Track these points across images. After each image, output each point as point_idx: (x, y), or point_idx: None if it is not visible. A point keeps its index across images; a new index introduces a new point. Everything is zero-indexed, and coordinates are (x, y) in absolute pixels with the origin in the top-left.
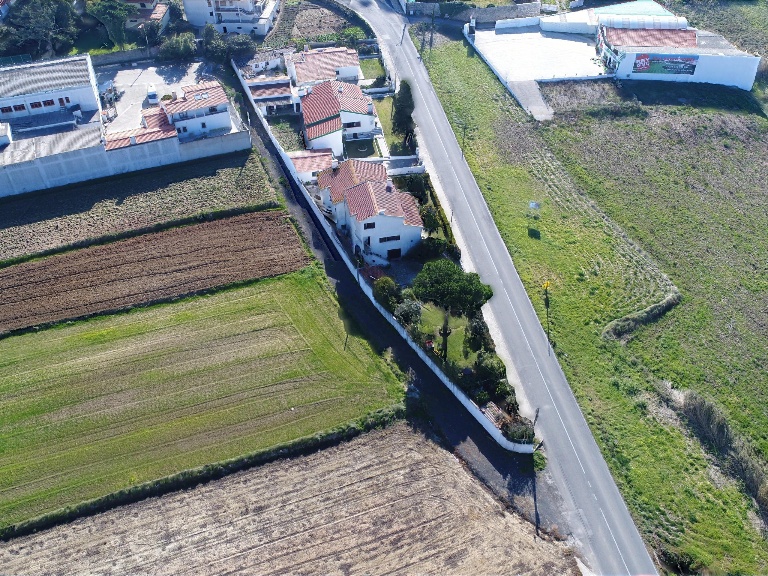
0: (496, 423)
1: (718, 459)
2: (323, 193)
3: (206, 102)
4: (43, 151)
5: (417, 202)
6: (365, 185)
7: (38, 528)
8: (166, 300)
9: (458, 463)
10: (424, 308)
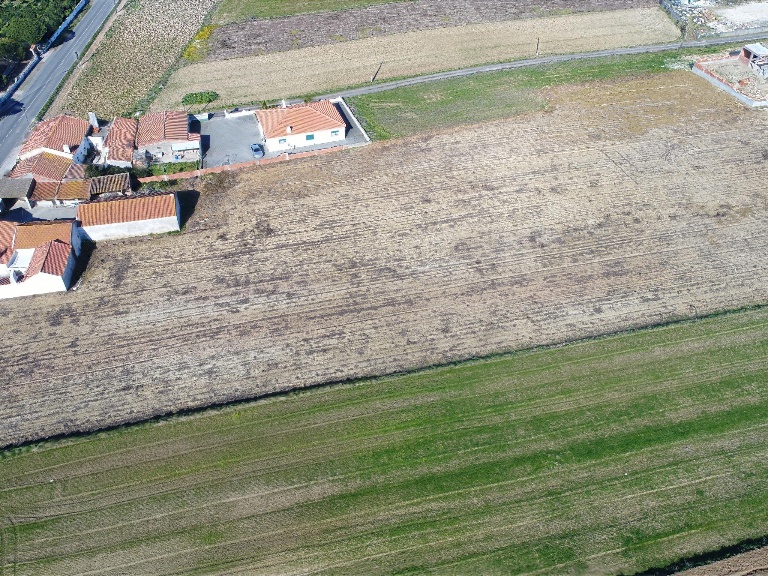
0: None
1: None
2: None
3: None
4: None
5: None
6: None
7: (323, 385)
8: None
9: None
10: None
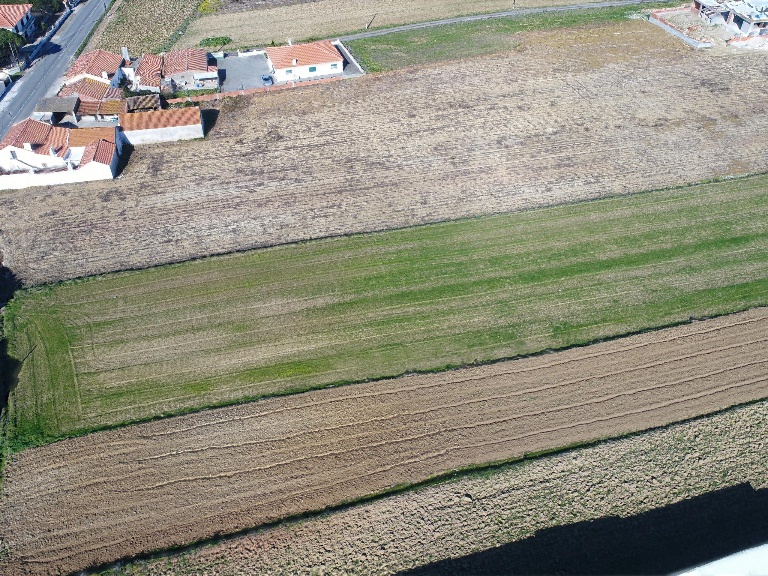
0: None
1: None
2: None
3: None
4: None
5: None
6: None
7: None
8: (216, 408)
9: None
10: None
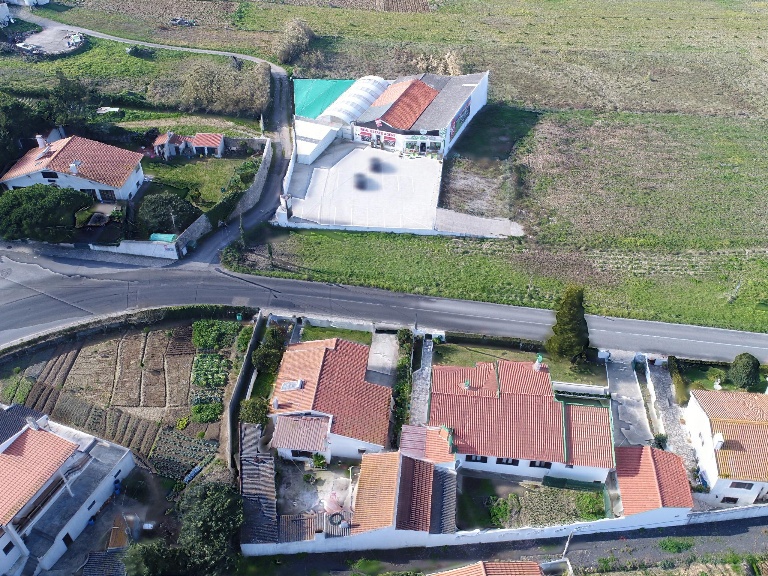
0: None
1: None
2: (766, 482)
3: None
4: None
5: None
6: None
7: None
8: None
9: None
10: None
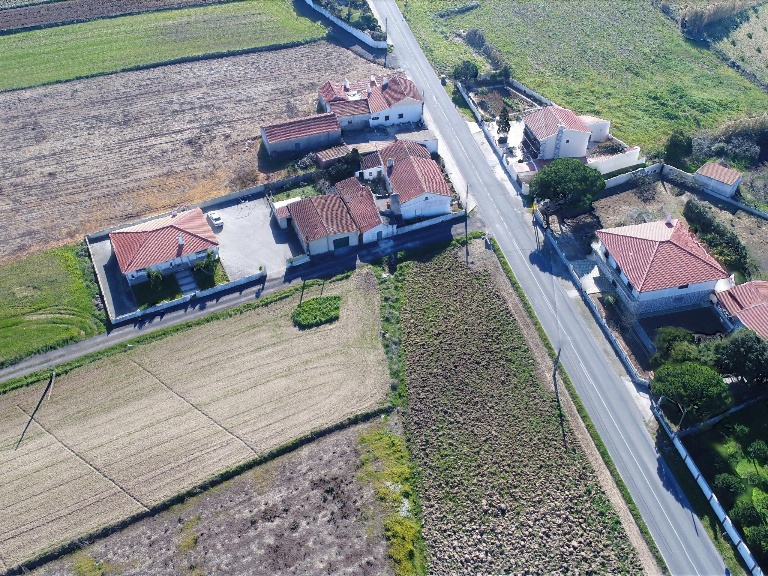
0: (369, 34)
1: (478, 50)
2: None
3: None
4: None
5: None
6: None
7: (151, 67)
8: (201, 5)
9: (351, 52)
10: (339, 8)
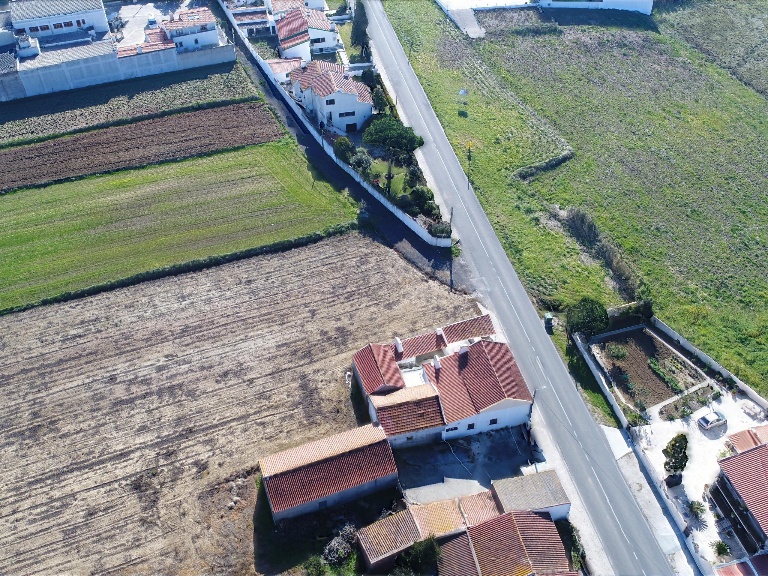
0: (424, 225)
1: (588, 248)
2: (295, 86)
3: (198, 21)
4: (67, 58)
5: (369, 89)
6: (327, 74)
7: (88, 294)
8: (173, 160)
9: (396, 254)
10: (374, 162)
